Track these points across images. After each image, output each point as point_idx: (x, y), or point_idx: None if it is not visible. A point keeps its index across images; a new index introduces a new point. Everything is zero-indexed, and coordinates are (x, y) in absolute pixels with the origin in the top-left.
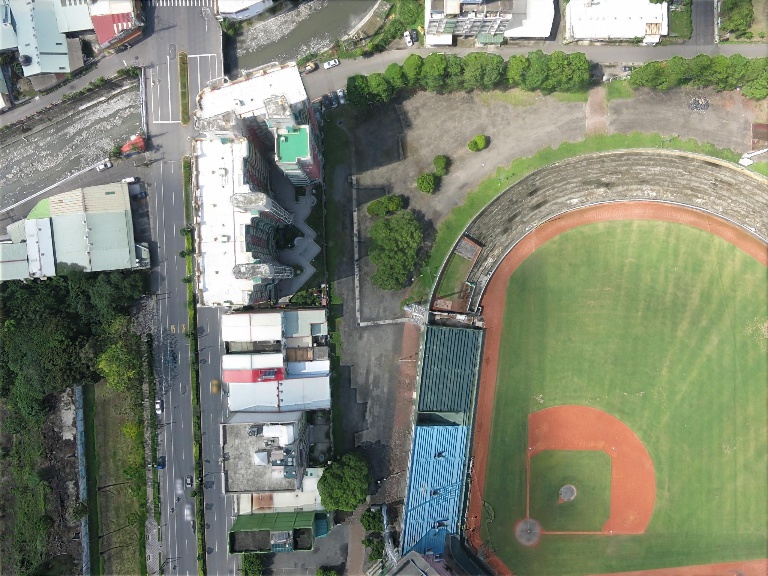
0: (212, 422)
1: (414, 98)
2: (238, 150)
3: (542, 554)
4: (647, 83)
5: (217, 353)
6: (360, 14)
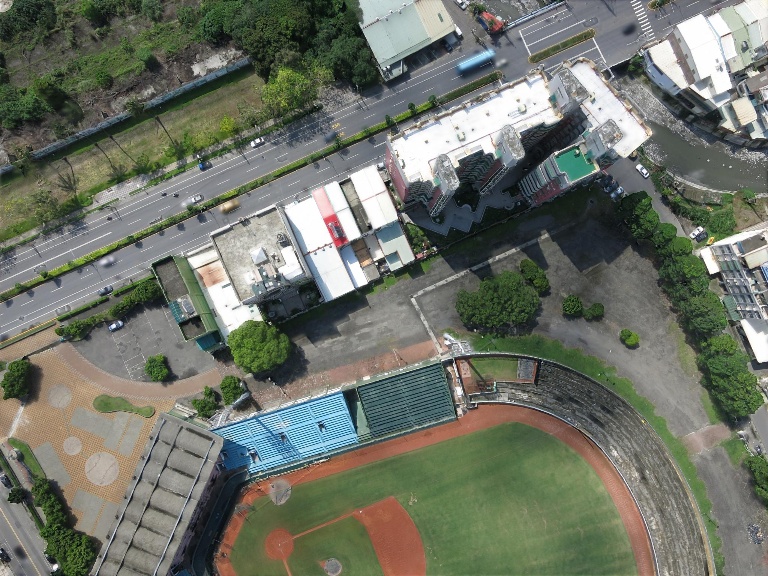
0: (263, 197)
1: (644, 260)
2: (549, 115)
3: (263, 567)
4: (759, 475)
5: (330, 176)
6: (698, 179)
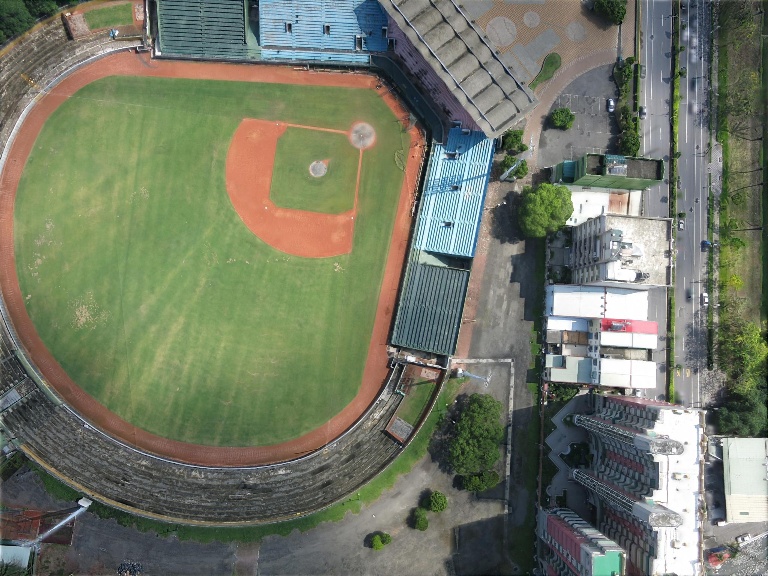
0: None
1: None
2: (660, 566)
3: (350, 112)
4: None
5: None
6: None
